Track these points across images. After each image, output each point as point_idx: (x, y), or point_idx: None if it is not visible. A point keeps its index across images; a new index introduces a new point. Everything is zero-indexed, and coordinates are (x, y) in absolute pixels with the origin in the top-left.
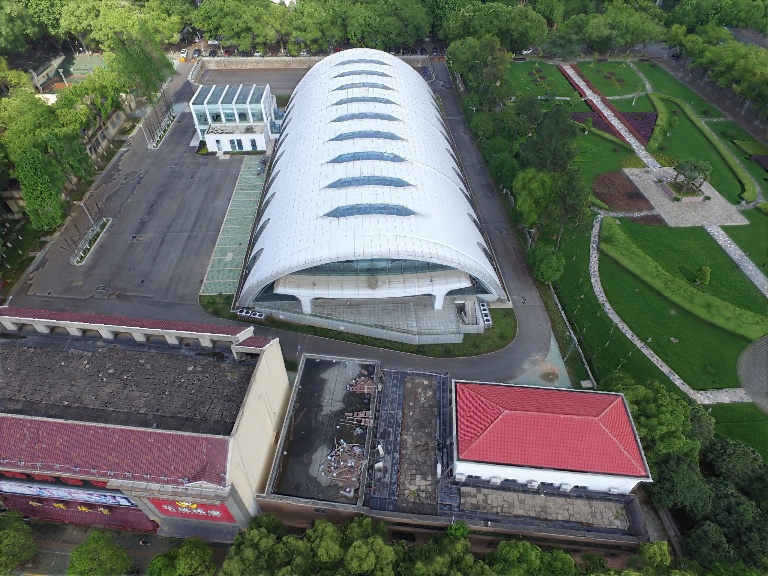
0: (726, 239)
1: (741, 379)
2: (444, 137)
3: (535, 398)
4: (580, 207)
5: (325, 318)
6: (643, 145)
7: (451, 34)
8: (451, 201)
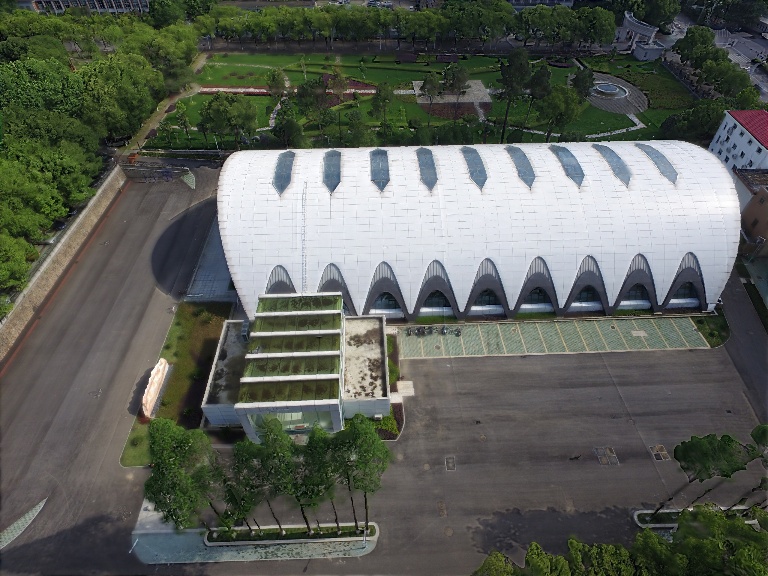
0: (501, 90)
1: (620, 113)
2: None
3: (760, 126)
4: None
5: None
6: None
7: (119, 121)
8: None
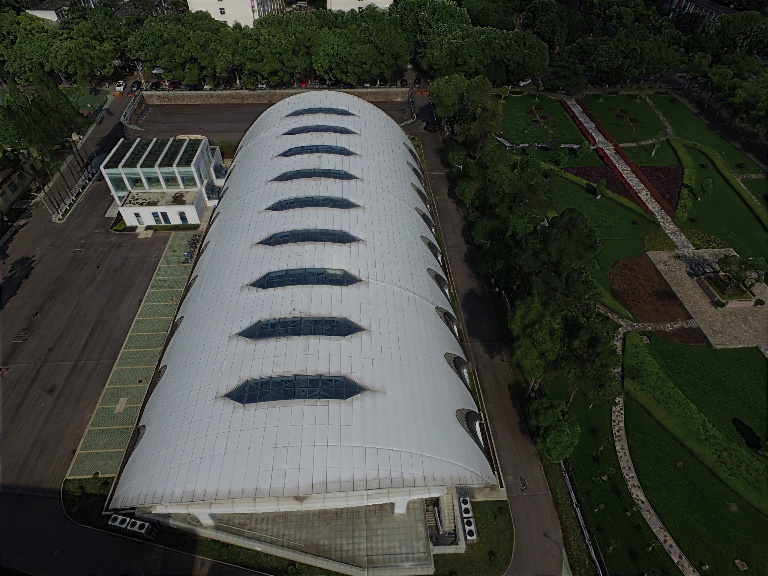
0: None
1: None
2: (420, 215)
3: None
4: (606, 381)
5: (234, 534)
6: (669, 215)
7: (436, 64)
8: (421, 343)
